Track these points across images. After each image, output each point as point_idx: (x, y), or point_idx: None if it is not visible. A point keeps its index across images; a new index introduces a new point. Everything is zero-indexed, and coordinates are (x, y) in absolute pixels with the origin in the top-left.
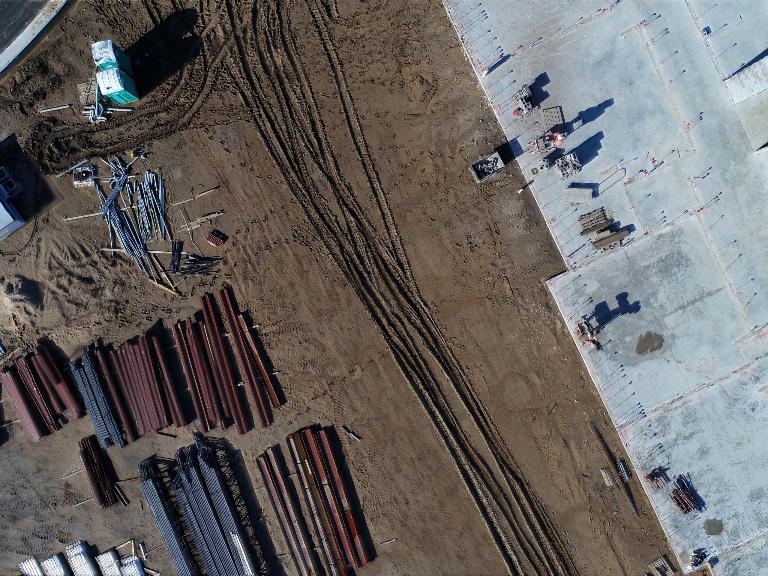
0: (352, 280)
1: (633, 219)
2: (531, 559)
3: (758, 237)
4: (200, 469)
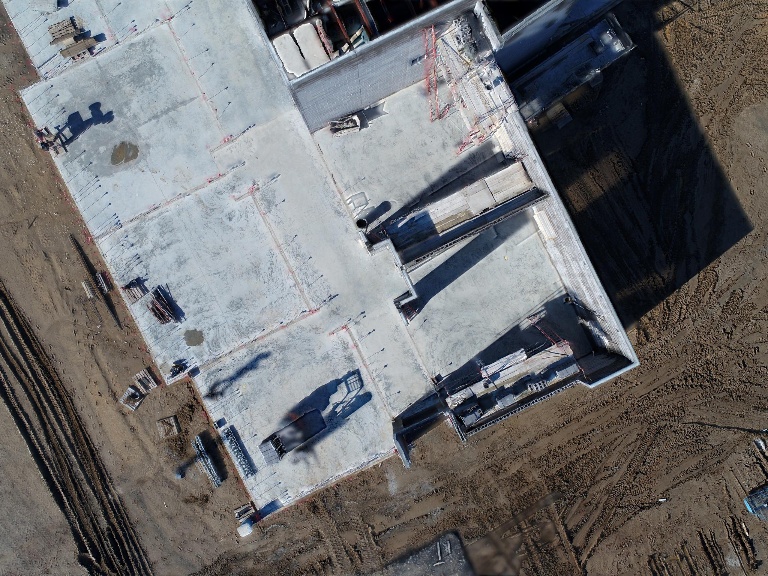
0: None
1: (103, 28)
2: (18, 374)
3: (230, 46)
4: None
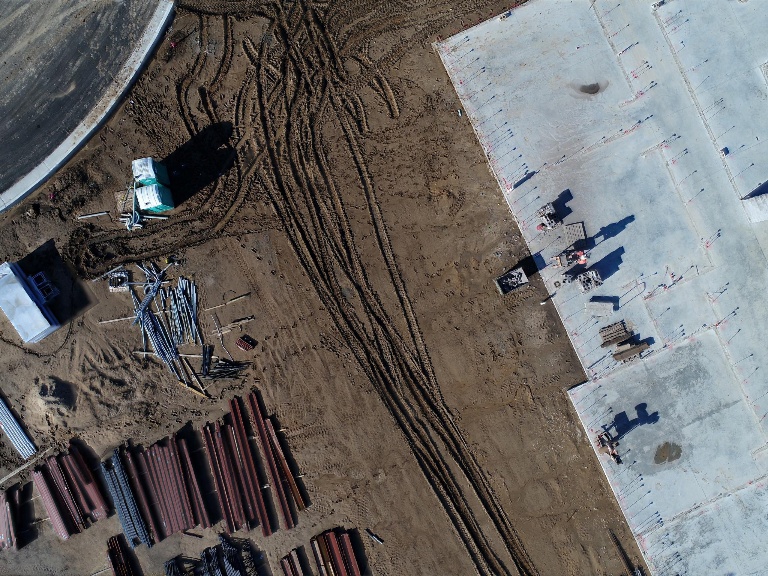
0: (378, 386)
1: (652, 332)
2: None
3: None
4: (226, 571)
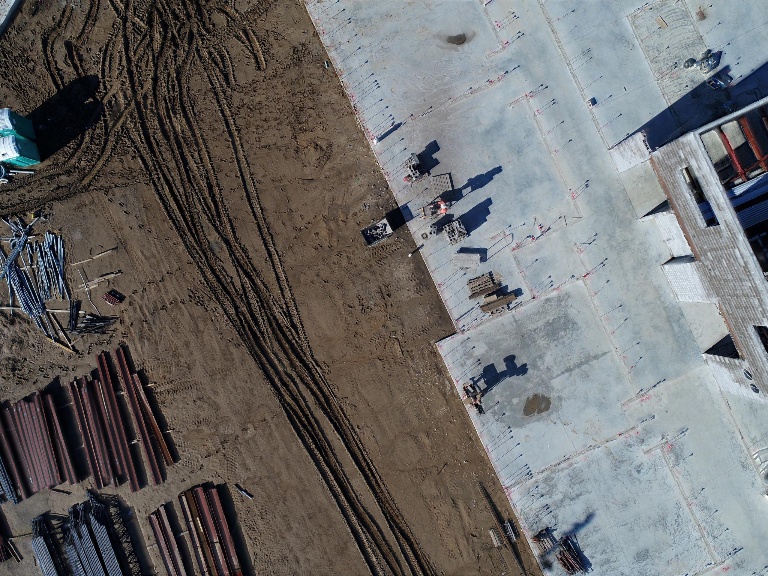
0: (246, 340)
1: (520, 283)
2: None
3: (643, 302)
4: (92, 526)
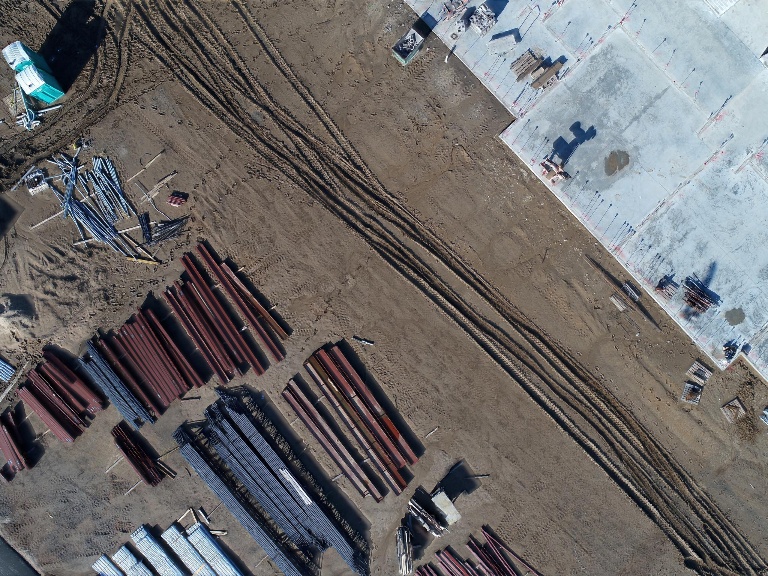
0: (317, 196)
1: (561, 51)
2: (572, 405)
3: (685, 29)
4: (232, 419)
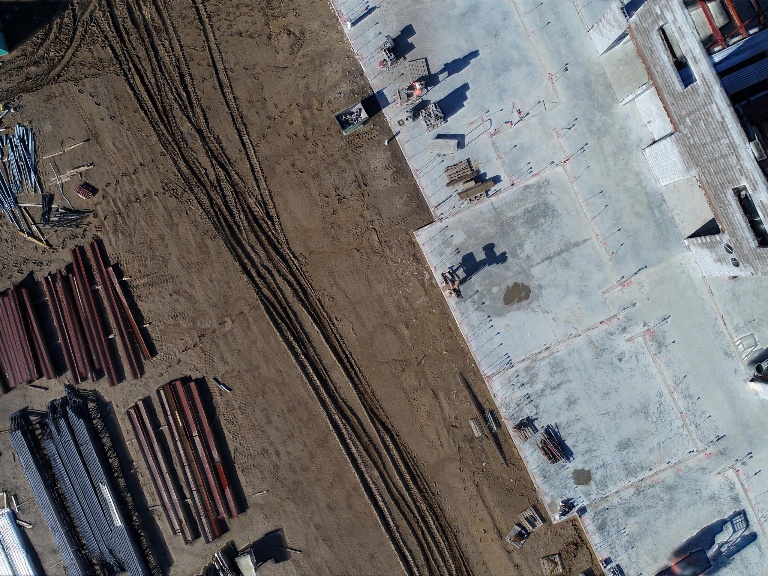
0: (222, 232)
1: (499, 170)
2: (402, 510)
3: (624, 188)
4: (70, 420)
